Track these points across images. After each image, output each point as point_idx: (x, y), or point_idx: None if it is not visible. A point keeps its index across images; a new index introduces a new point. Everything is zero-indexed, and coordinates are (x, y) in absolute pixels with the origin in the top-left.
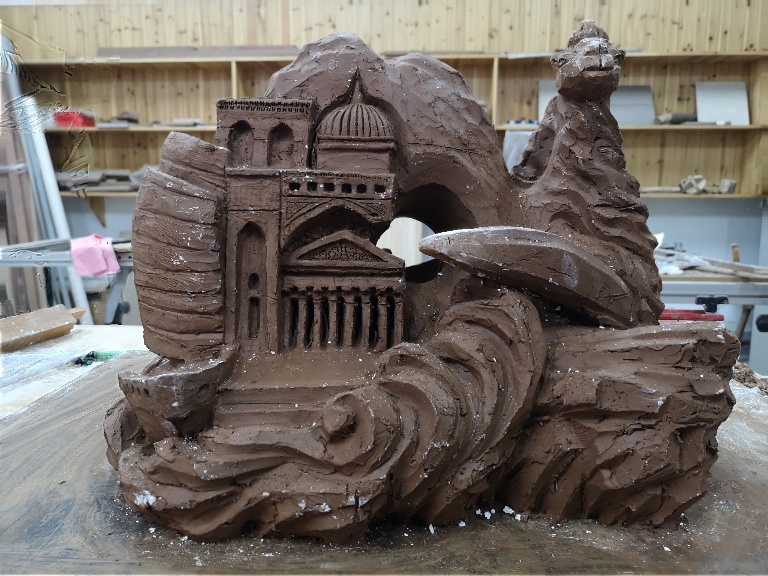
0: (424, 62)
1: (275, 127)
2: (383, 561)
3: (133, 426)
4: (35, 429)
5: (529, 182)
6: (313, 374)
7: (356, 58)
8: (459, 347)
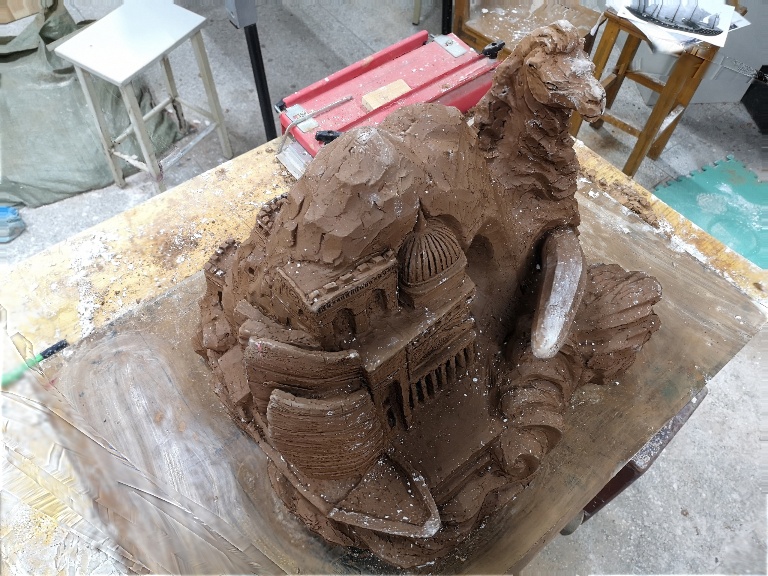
0: (443, 131)
1: (369, 296)
2: (531, 487)
3: (341, 523)
4: None
5: (491, 157)
6: (461, 434)
7: (415, 188)
8: (545, 376)
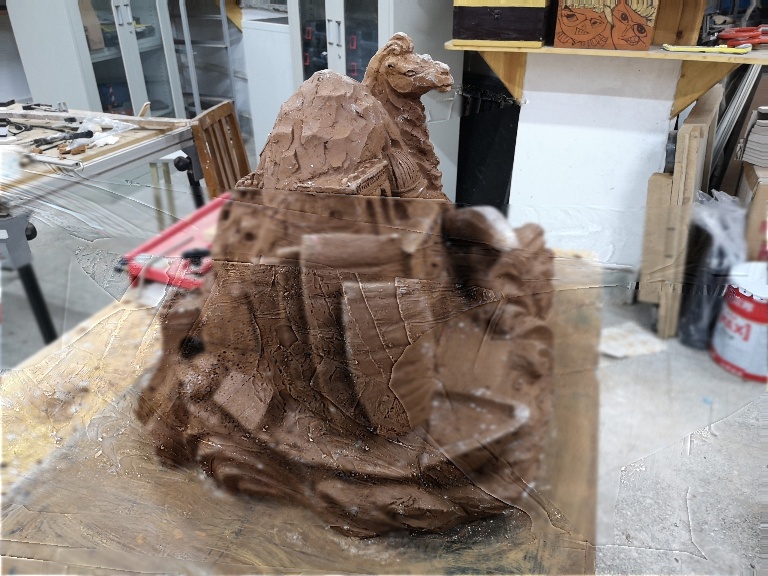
0: None
1: None
2: None
3: None
4: None
5: None
6: None
7: None
8: None
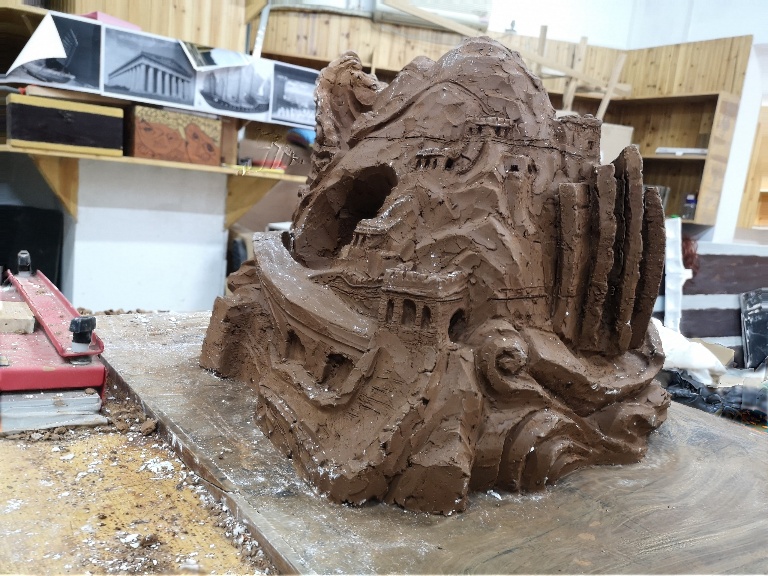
0: None
1: None
2: None
3: None
4: (757, 542)
5: None
6: None
7: None
8: None
